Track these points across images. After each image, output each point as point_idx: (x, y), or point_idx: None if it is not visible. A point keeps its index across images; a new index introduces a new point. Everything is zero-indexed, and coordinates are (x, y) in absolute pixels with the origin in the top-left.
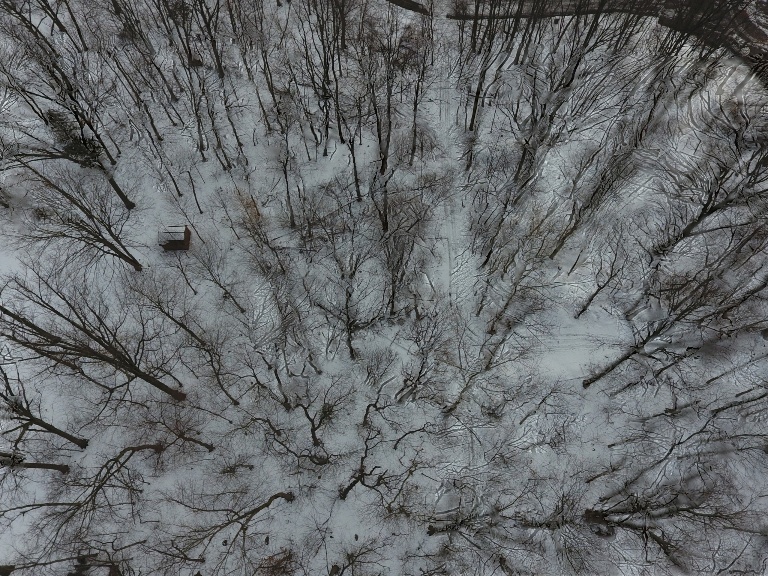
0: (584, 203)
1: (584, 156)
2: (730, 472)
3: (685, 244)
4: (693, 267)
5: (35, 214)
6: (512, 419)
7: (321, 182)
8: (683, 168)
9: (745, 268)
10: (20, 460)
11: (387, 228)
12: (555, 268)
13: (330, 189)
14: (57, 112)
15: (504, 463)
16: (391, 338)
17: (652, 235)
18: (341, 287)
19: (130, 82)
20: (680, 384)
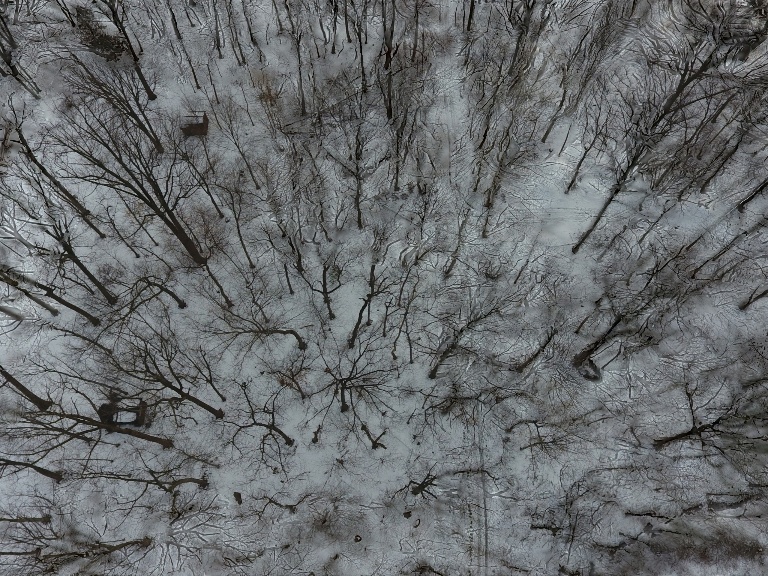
0: (573, 91)
1: (573, 43)
2: (707, 325)
3: (666, 122)
4: (674, 147)
5: (64, 104)
6: (507, 279)
7: (330, 76)
8: (661, 35)
9: (720, 138)
10: (55, 314)
11: (391, 115)
12: (547, 151)
13: (338, 82)
14: (85, 9)
15: (500, 317)
16: (395, 210)
17: (632, 88)
18: (349, 167)
19: None
20: (662, 250)
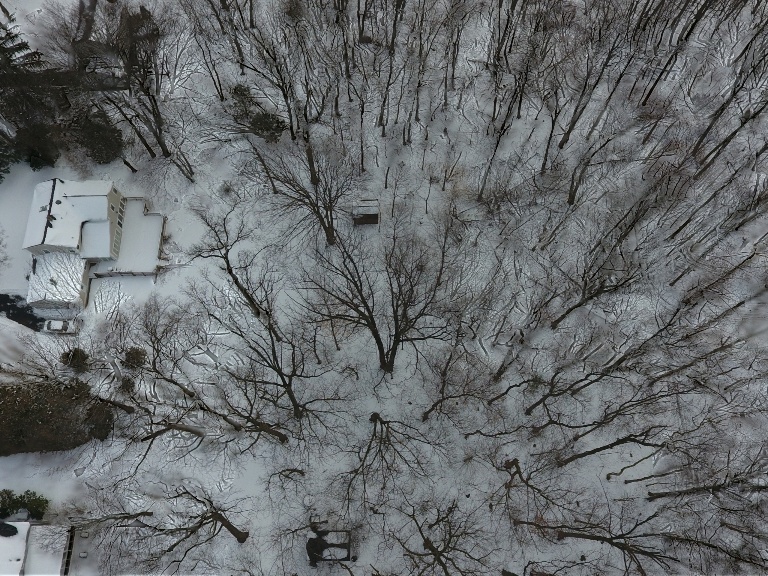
0: (767, 175)
1: None
2: None
3: None
4: None
5: (222, 189)
6: (716, 385)
7: (501, 156)
8: None
9: None
10: (239, 429)
11: (573, 200)
12: (740, 239)
13: (511, 163)
14: (244, 87)
15: (713, 427)
16: (588, 307)
17: None
18: (533, 258)
19: (308, 58)
20: None
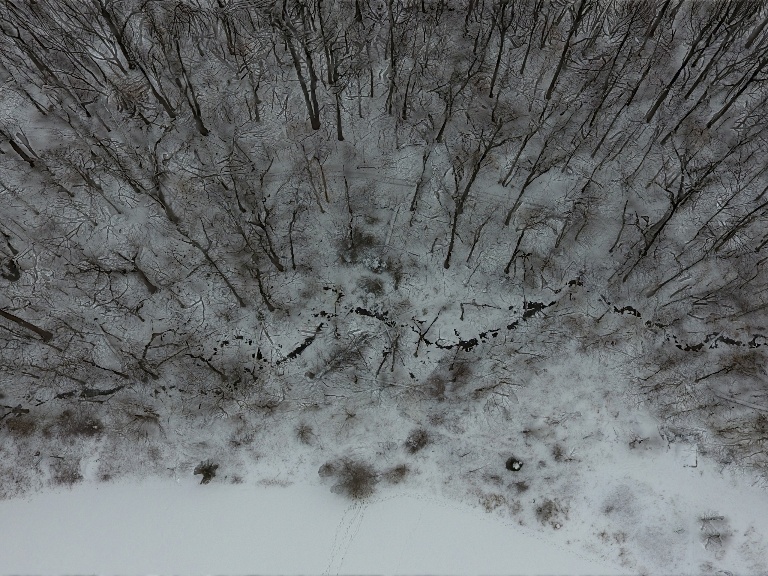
0: None
1: None
2: (135, 234)
3: (128, 49)
4: None
5: None
6: None
7: None
8: None
9: None
10: None
11: None
12: None
13: None
14: None
15: None
16: None
17: None
18: None
19: None
20: None
